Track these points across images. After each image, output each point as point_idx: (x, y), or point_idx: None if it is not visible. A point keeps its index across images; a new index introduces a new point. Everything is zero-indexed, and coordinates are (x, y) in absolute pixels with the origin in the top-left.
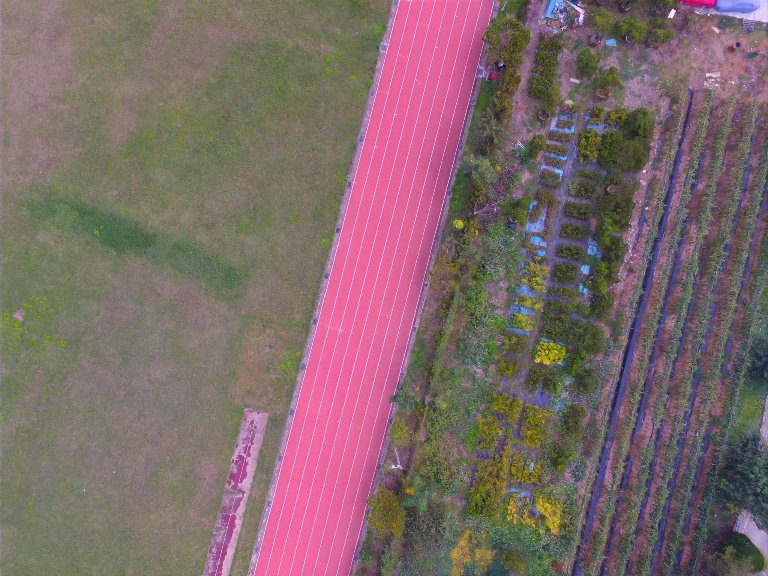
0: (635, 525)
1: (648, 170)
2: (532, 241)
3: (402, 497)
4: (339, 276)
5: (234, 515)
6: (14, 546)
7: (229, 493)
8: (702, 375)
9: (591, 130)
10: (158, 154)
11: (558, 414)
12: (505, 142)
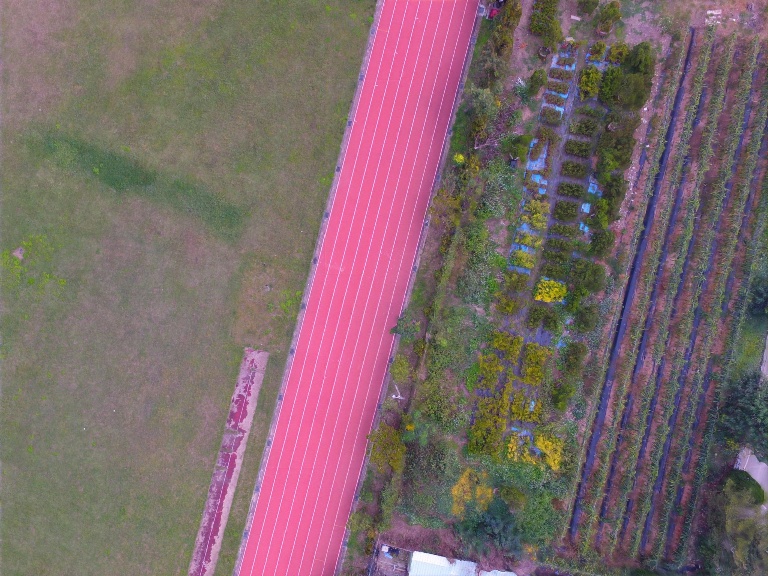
0: (636, 462)
1: (649, 108)
2: (533, 179)
3: (402, 433)
4: (339, 215)
5: (234, 454)
6: (14, 484)
7: (229, 432)
8: (703, 313)
9: (592, 66)
10: (158, 92)
11: (559, 352)
12: (506, 75)
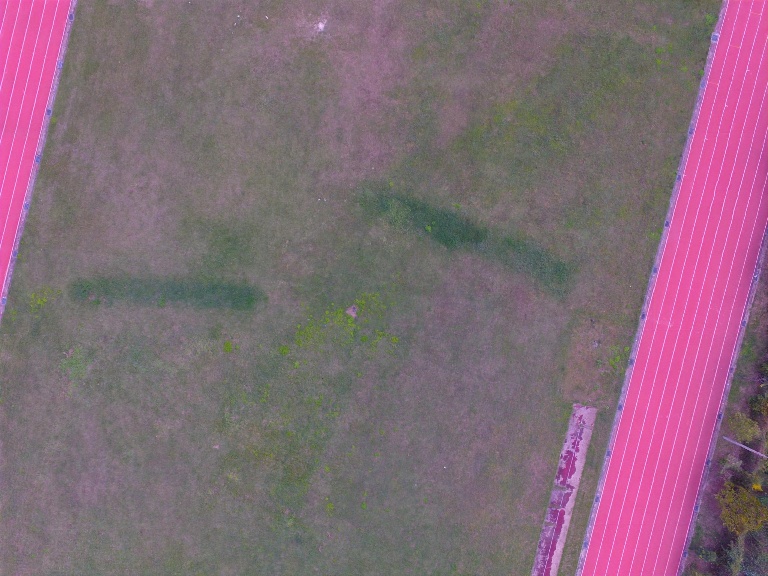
0: None
1: None
2: None
3: (753, 493)
4: (668, 270)
5: (563, 510)
6: (348, 540)
7: (558, 488)
8: None
9: None
10: (488, 149)
11: None
12: None
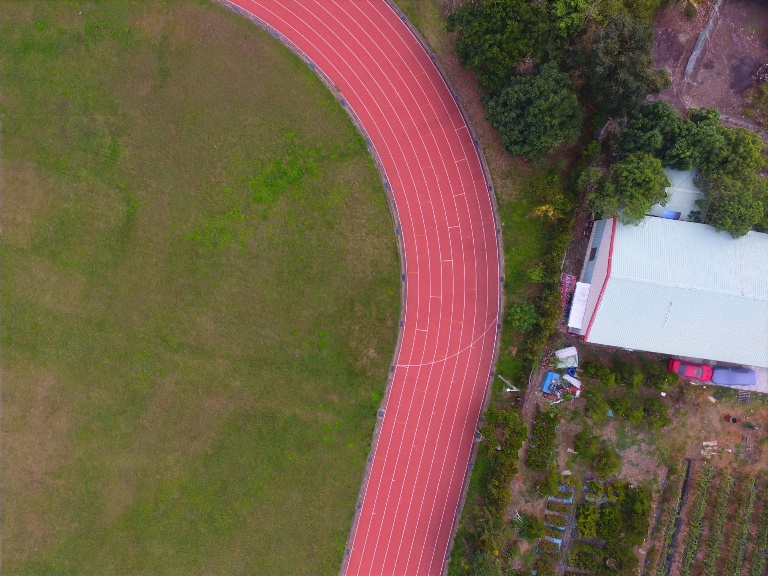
0: None
1: (647, 539)
2: None
3: None
4: None
5: None
6: None
7: None
8: None
9: (589, 508)
10: (155, 527)
11: None
12: None
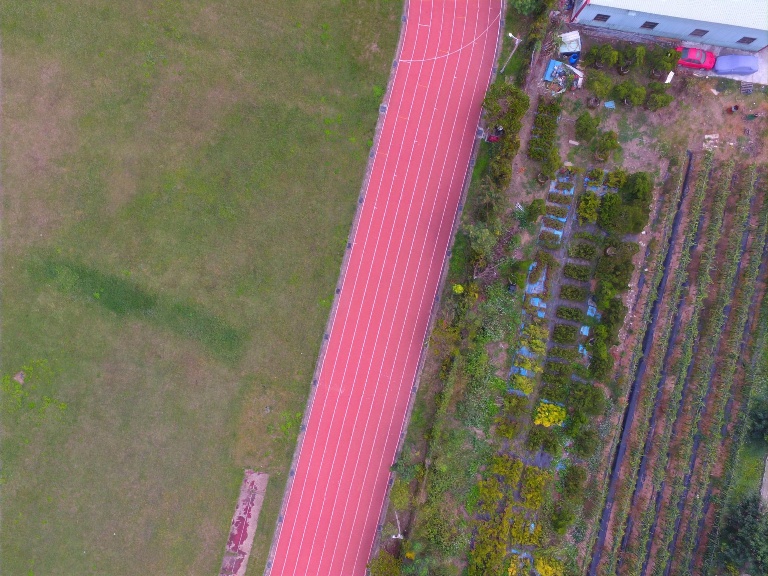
0: None
1: (647, 231)
2: (532, 302)
3: (402, 562)
4: (339, 337)
5: None
6: None
7: (229, 554)
8: (702, 436)
9: (590, 193)
10: (158, 216)
11: (558, 475)
12: (504, 208)
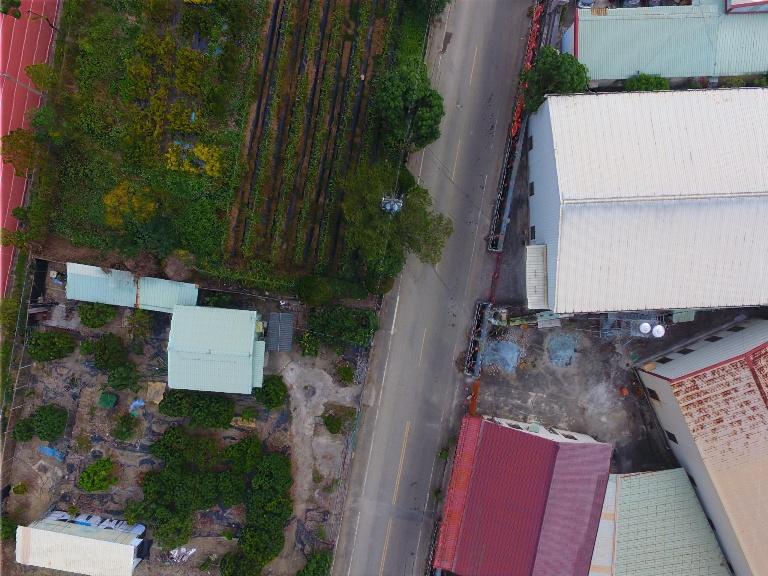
0: (293, 163)
1: None
2: None
3: None
4: None
5: None
6: None
7: None
8: None
9: None
10: None
11: (216, 59)
12: None
